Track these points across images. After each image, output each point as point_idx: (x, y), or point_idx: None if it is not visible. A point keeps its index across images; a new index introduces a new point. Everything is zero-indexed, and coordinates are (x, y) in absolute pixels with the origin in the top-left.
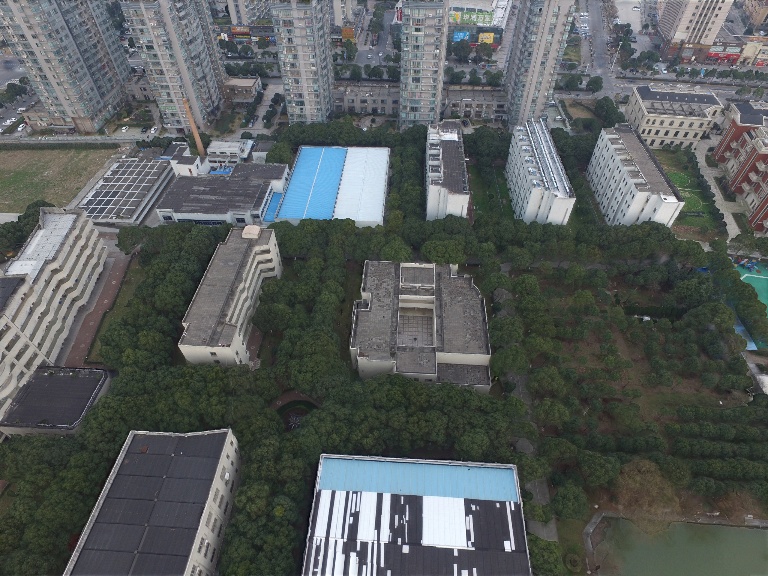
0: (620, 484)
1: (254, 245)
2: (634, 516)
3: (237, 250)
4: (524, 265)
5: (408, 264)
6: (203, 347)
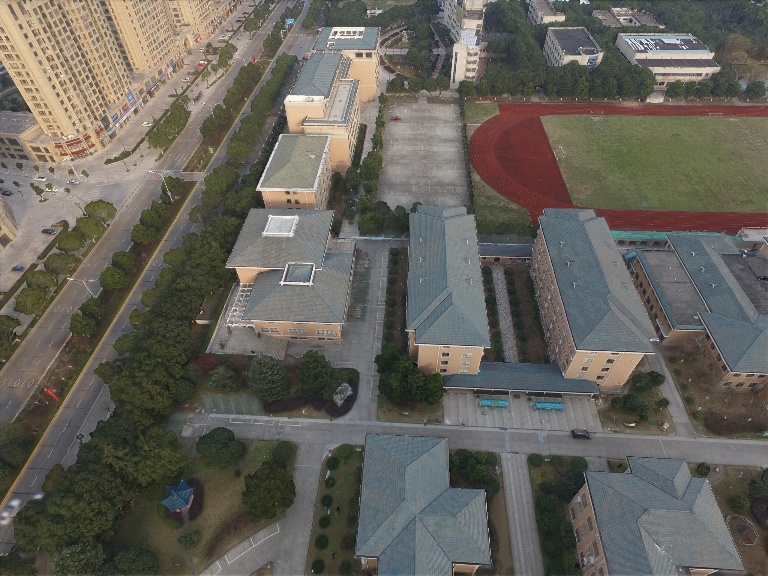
0: (728, 38)
1: (546, 0)
2: (734, 45)
3: (541, 0)
4: (668, 7)
5: (615, 9)
6: (554, 16)
